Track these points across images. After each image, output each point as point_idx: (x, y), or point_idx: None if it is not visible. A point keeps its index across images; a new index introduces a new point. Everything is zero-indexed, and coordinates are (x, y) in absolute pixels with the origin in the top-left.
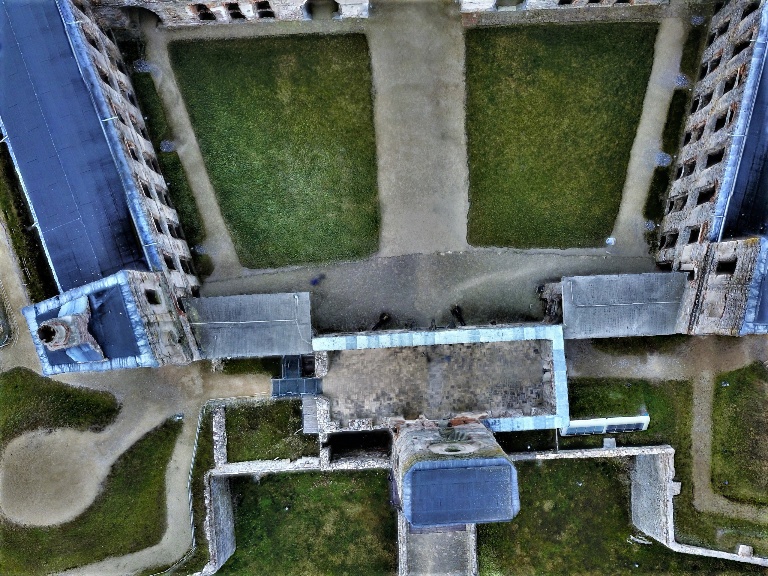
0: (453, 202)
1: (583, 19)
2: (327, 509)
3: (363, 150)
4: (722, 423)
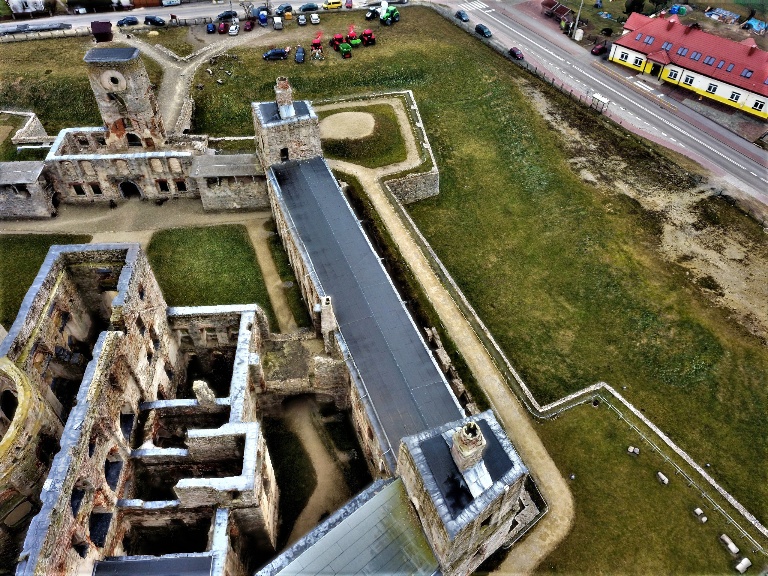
0: None
1: None
2: None
3: None
4: None
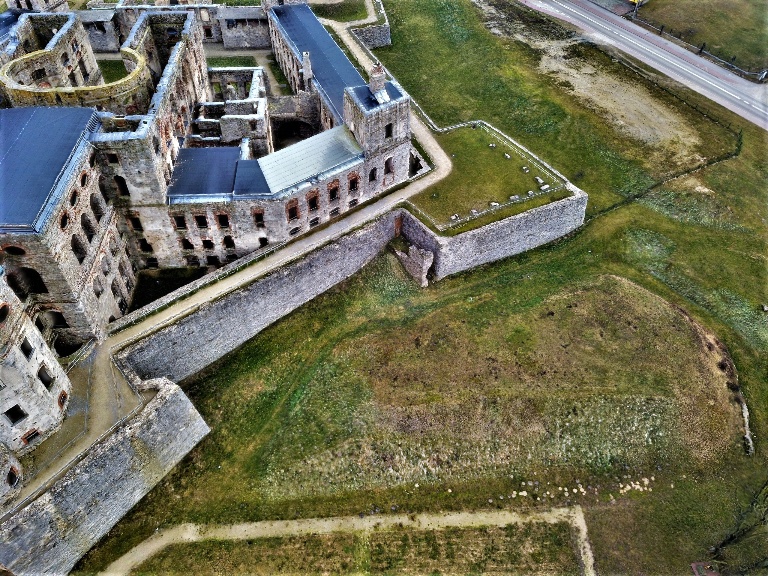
0: None
1: None
2: None
3: None
4: None
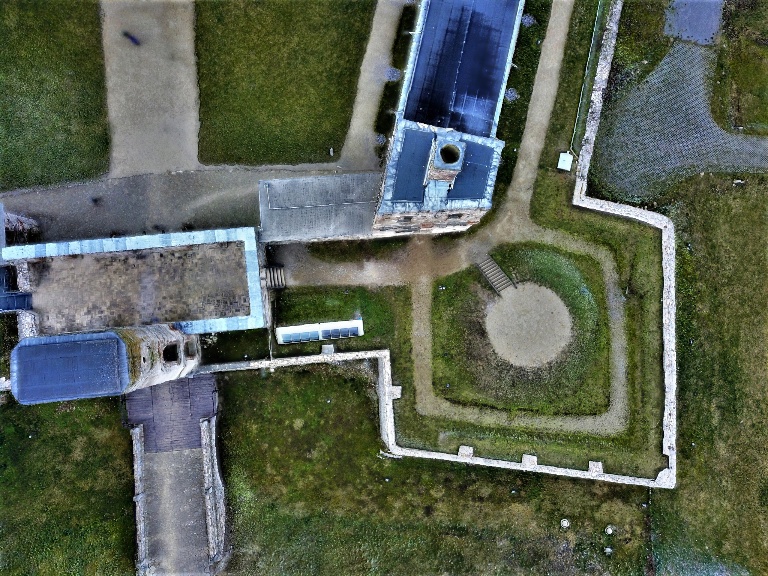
0: (184, 122)
1: None
2: (73, 436)
3: (92, 73)
4: (441, 326)
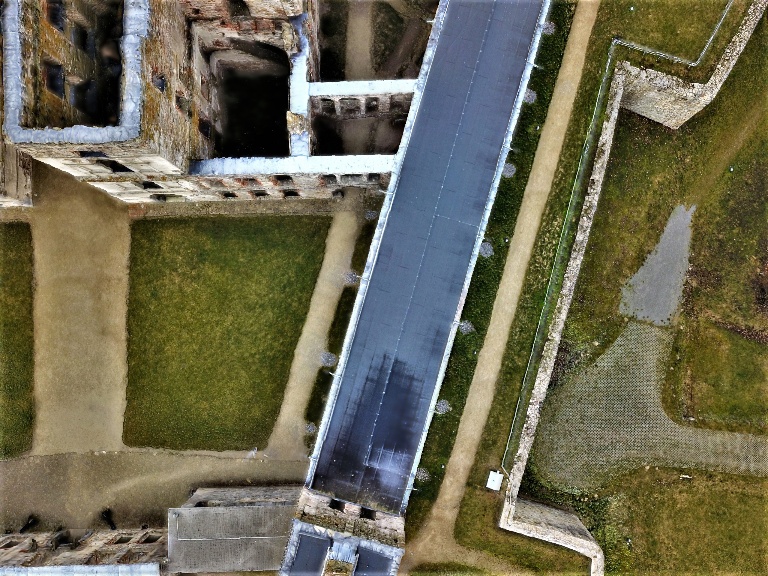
0: (110, 400)
1: (254, 211)
2: None
3: (20, 344)
4: None
